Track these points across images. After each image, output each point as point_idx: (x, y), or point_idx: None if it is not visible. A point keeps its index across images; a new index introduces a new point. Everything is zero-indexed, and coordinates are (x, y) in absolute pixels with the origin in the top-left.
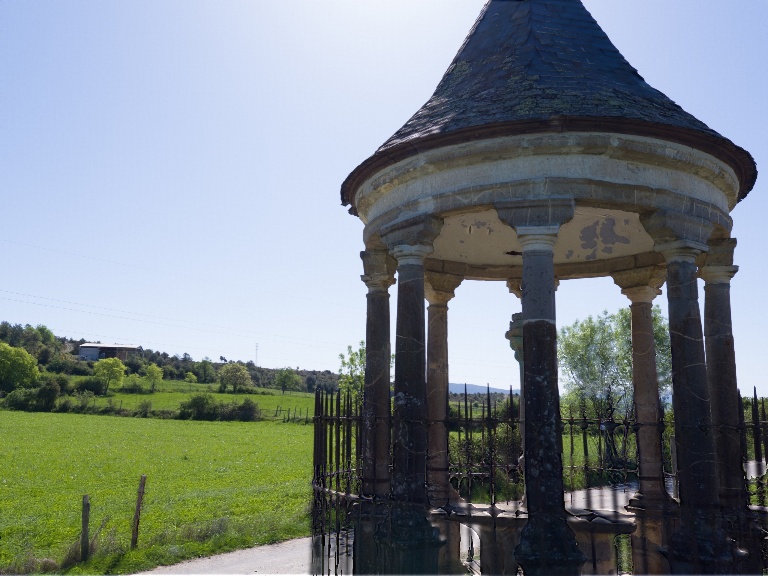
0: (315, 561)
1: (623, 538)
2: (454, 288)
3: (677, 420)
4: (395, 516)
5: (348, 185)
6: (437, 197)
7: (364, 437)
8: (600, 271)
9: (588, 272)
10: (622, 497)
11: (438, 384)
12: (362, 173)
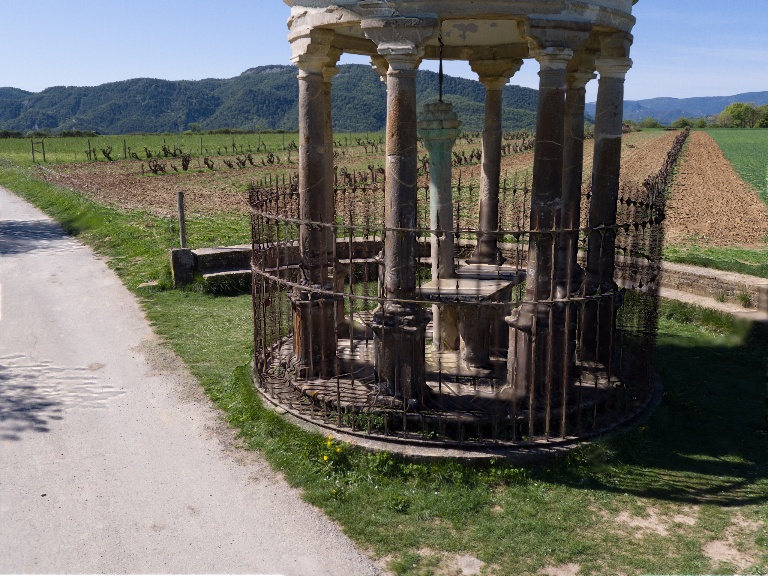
0: (54, 443)
1: (187, 297)
2: None
3: (571, 197)
4: (555, 306)
5: None
6: (603, 9)
7: (406, 245)
8: (373, 51)
9: (364, 50)
10: (21, 261)
11: (325, 171)
12: None
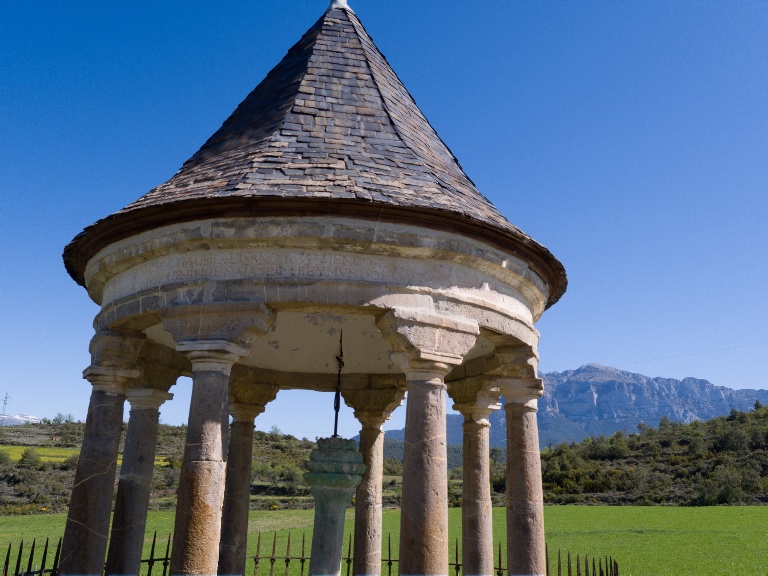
0: None
1: None
2: (478, 394)
3: None
4: None
5: None
6: None
7: None
8: None
9: None
10: None
11: None
12: None
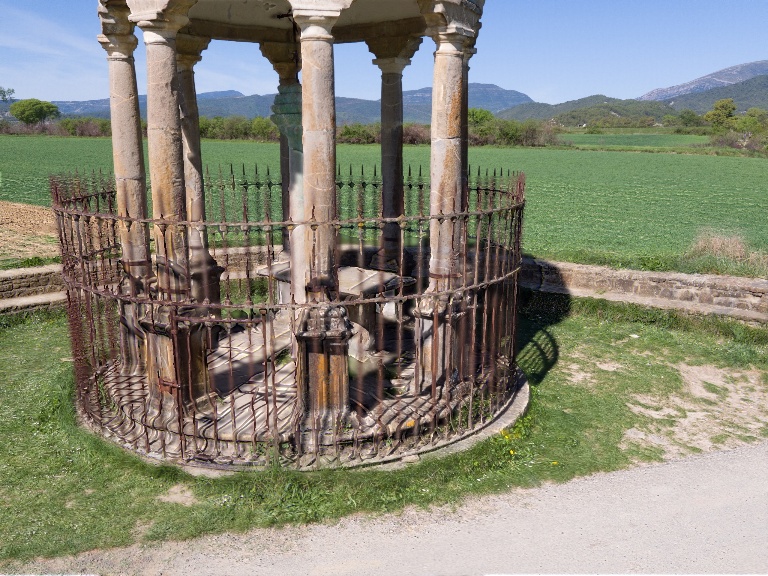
0: None
1: None
2: None
3: None
4: None
5: None
6: None
7: None
8: None
9: None
10: None
11: None
12: None
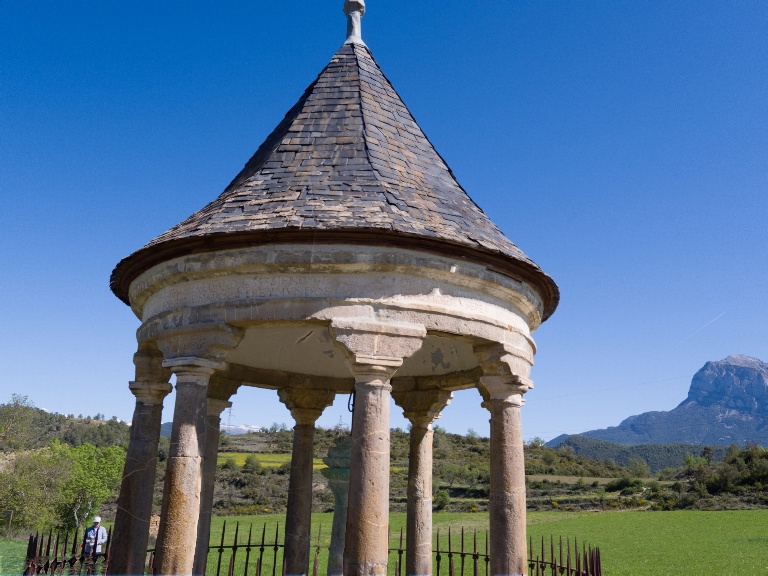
0: None
1: None
2: None
3: None
4: None
5: None
6: None
7: None
8: None
9: None
10: None
11: None
12: None
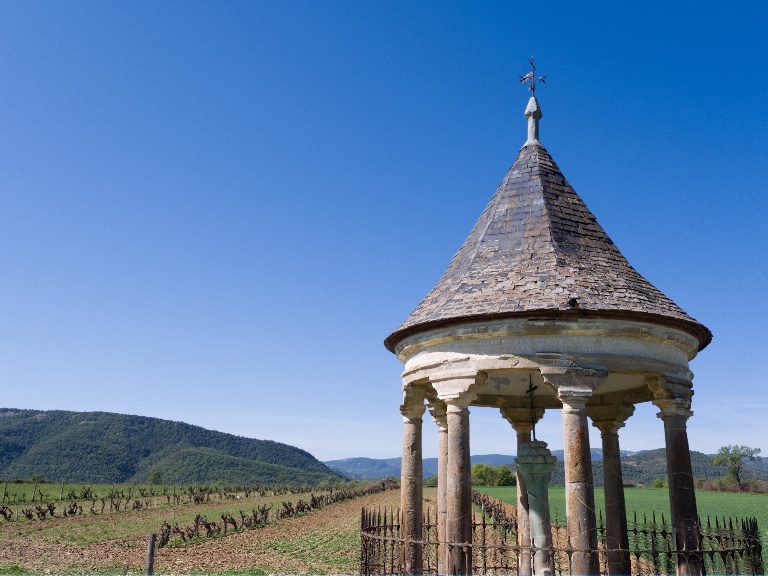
0: None
1: None
2: None
3: None
4: None
5: (643, 313)
6: None
7: (597, 569)
8: None
9: None
10: None
11: None
12: (669, 320)
